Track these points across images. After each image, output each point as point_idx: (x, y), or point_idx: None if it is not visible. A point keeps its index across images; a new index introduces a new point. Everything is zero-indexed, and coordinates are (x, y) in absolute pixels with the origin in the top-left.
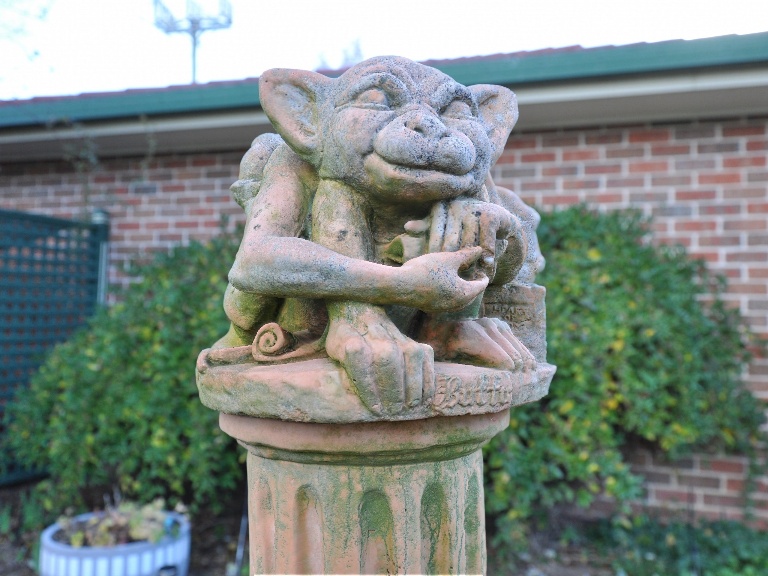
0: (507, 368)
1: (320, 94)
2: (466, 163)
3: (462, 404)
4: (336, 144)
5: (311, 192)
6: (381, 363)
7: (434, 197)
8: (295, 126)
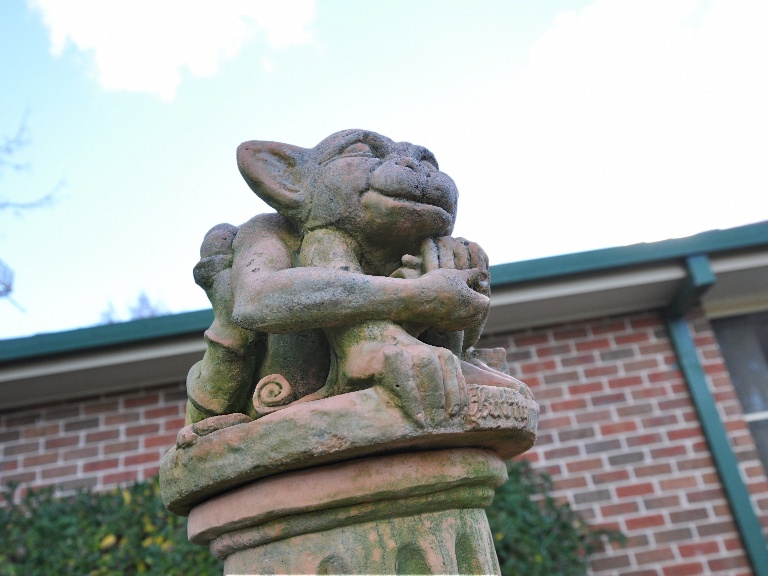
0: None
1: (300, 159)
2: (451, 198)
3: (493, 415)
4: (330, 189)
5: (293, 252)
6: (422, 364)
7: (427, 230)
8: (279, 186)
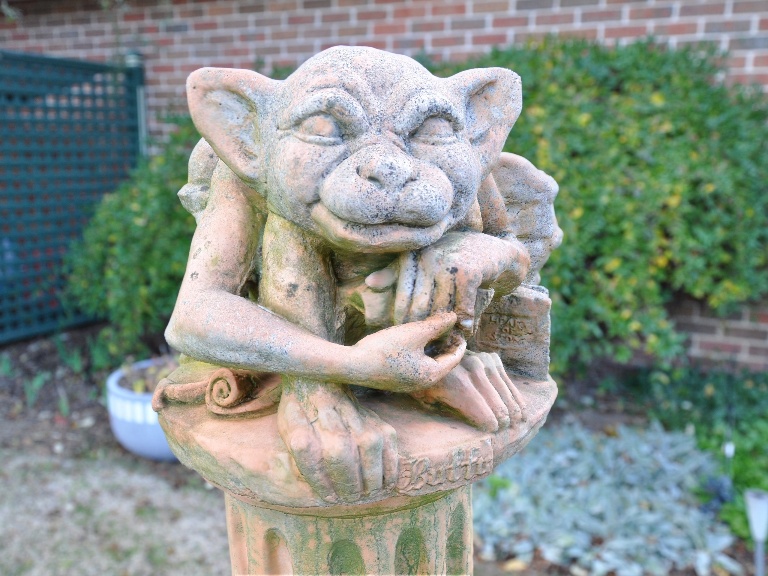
0: (489, 431)
1: (261, 106)
2: (437, 216)
3: (431, 485)
4: (277, 184)
5: (263, 216)
6: (331, 462)
7: None
8: (233, 147)
